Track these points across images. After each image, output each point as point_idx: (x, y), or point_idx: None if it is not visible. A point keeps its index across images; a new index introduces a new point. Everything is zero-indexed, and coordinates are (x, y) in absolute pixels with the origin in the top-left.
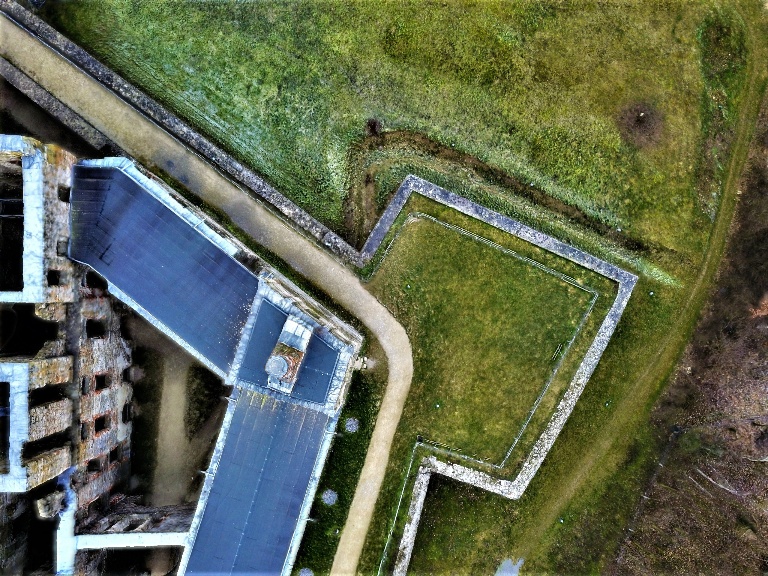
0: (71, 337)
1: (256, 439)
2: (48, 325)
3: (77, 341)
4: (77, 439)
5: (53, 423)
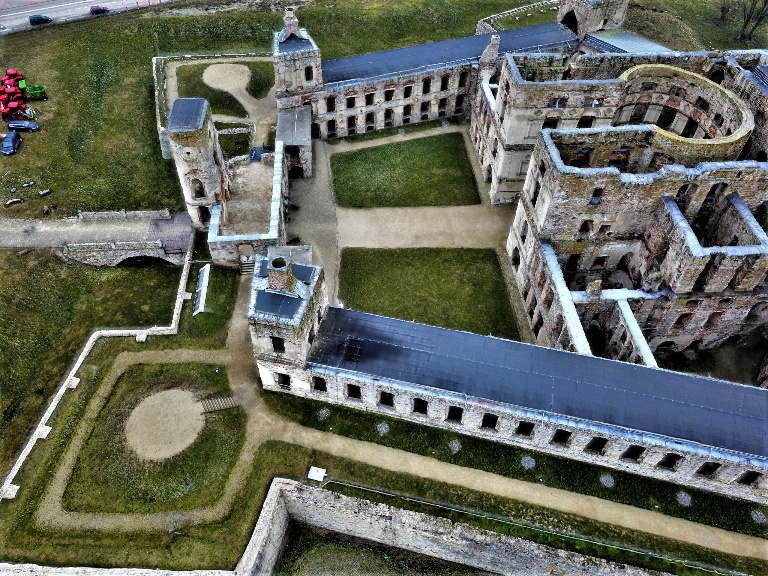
0: (764, 289)
1: (763, 408)
2: (766, 276)
3: (763, 293)
4: (695, 296)
5: (720, 276)
